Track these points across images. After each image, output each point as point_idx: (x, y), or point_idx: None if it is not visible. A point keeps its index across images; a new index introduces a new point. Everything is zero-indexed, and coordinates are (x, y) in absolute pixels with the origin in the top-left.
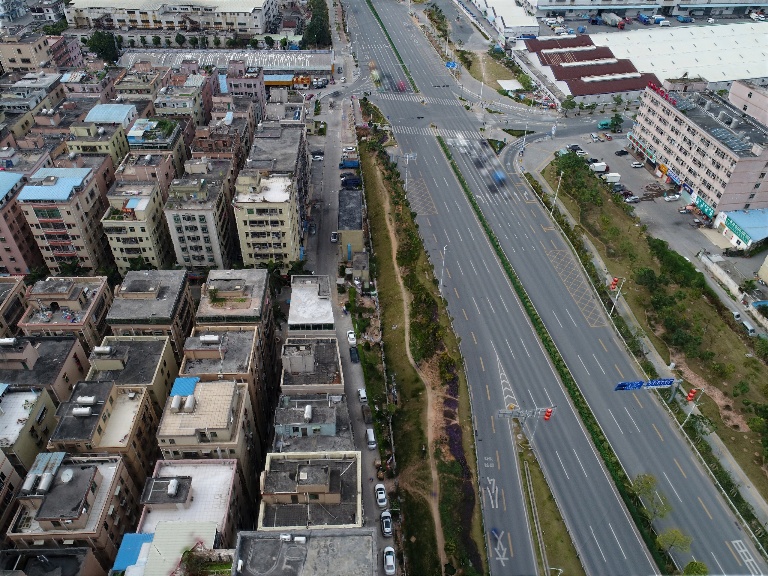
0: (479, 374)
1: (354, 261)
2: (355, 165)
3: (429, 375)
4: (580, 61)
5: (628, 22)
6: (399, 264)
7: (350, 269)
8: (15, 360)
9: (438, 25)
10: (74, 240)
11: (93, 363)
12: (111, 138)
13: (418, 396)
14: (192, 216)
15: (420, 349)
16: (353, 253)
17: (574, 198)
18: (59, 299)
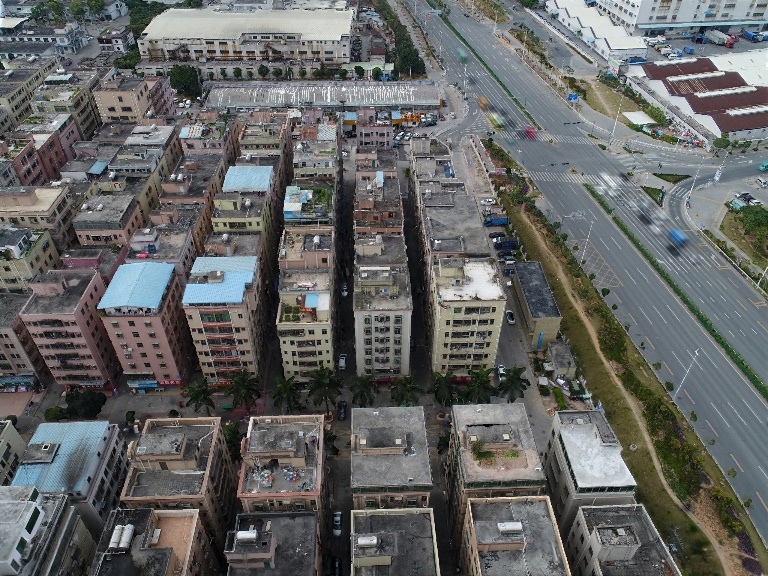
0: (765, 518)
1: (555, 355)
2: (503, 222)
3: (707, 522)
4: (717, 90)
5: (734, 40)
6: (608, 358)
7: (549, 364)
8: (257, 560)
9: (532, 48)
10: (240, 344)
11: (356, 560)
12: (262, 212)
13: (703, 553)
14: (386, 316)
15: (680, 482)
16: (549, 344)
17: None
18: (282, 456)
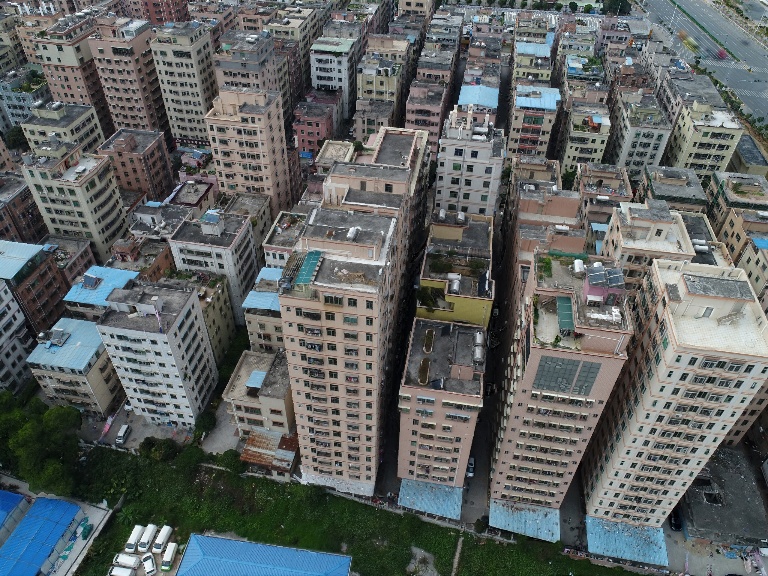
0: None
1: None
2: None
3: None
4: None
5: None
6: None
7: None
8: (606, 213)
9: (727, 2)
10: (540, 145)
11: None
12: None
13: None
14: (651, 134)
15: None
16: None
17: None
18: (608, 177)
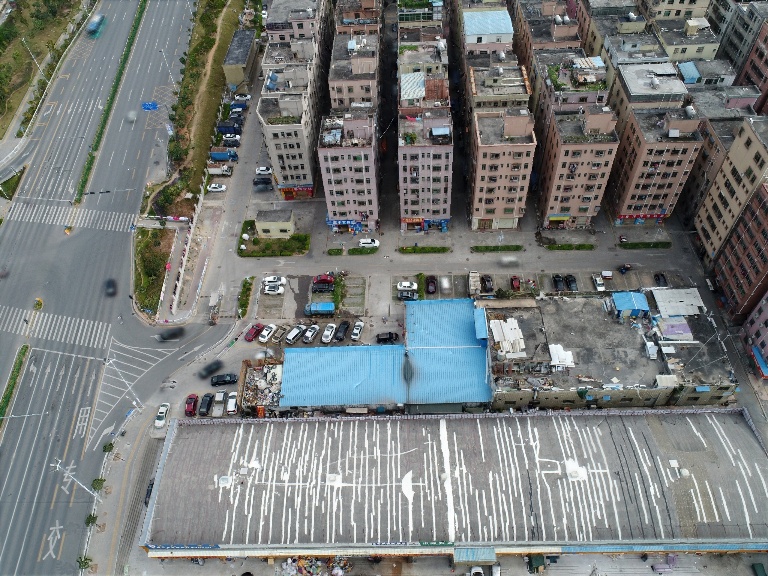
0: None
1: None
2: None
3: None
4: None
5: None
6: None
7: None
8: None
9: None
10: None
11: None
12: None
13: None
14: None
15: None
16: None
17: (6, 102)
18: None
